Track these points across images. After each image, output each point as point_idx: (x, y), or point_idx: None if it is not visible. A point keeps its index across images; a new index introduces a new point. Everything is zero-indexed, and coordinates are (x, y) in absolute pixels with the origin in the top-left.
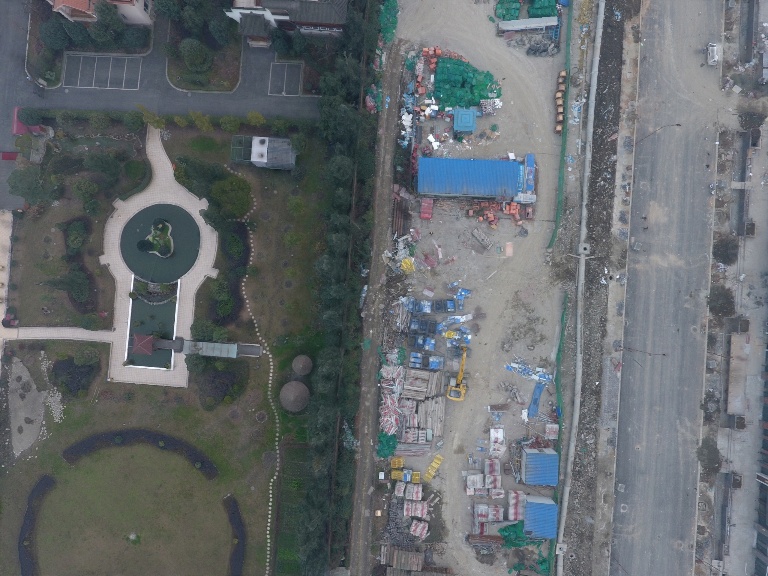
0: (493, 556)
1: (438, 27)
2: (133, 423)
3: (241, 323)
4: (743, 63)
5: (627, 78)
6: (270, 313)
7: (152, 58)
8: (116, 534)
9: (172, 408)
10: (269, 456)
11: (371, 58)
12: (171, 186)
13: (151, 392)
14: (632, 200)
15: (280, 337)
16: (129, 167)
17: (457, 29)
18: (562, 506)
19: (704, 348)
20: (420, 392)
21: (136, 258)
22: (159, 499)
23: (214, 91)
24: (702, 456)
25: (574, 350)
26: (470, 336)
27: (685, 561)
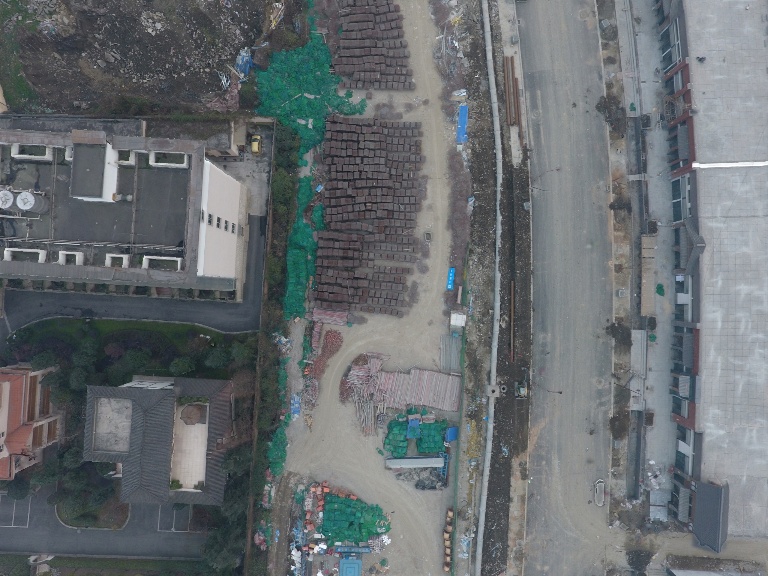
0: None
1: (327, 459)
2: None
3: None
4: (630, 500)
5: (515, 516)
6: None
7: (41, 495)
8: None
9: None
10: None
11: (258, 500)
12: None
13: None
14: None
15: None
16: None
17: (346, 462)
18: None
19: None
20: None
21: None
22: None
23: (103, 528)
24: None
25: None
26: None
27: None
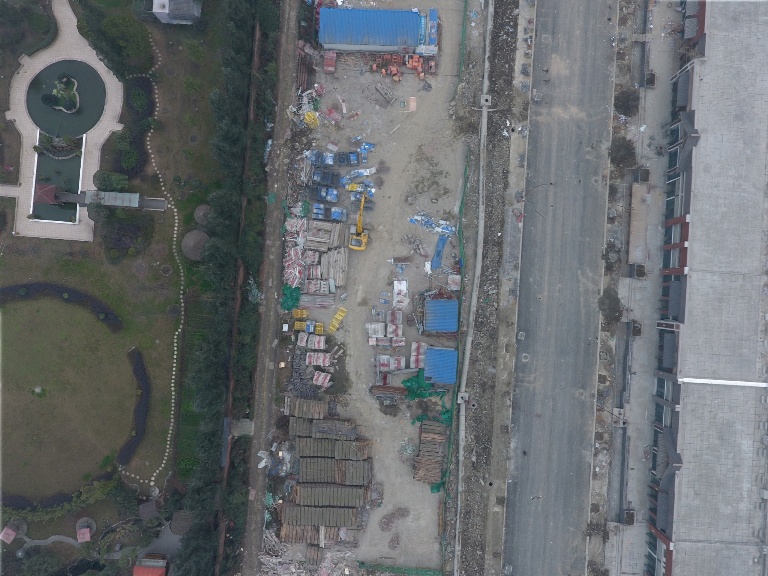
0: (397, 407)
1: None
2: (39, 277)
3: (145, 176)
4: None
5: None
6: (175, 168)
7: None
8: (21, 387)
9: (77, 262)
10: (173, 309)
11: None
12: (77, 42)
13: (57, 246)
14: (534, 53)
15: (175, 176)
16: (32, 18)
17: None
18: (464, 356)
19: (605, 199)
20: (323, 243)
21: (42, 114)
22: (64, 352)
23: None
24: (603, 305)
25: (477, 203)
26: (374, 189)
27: (586, 410)
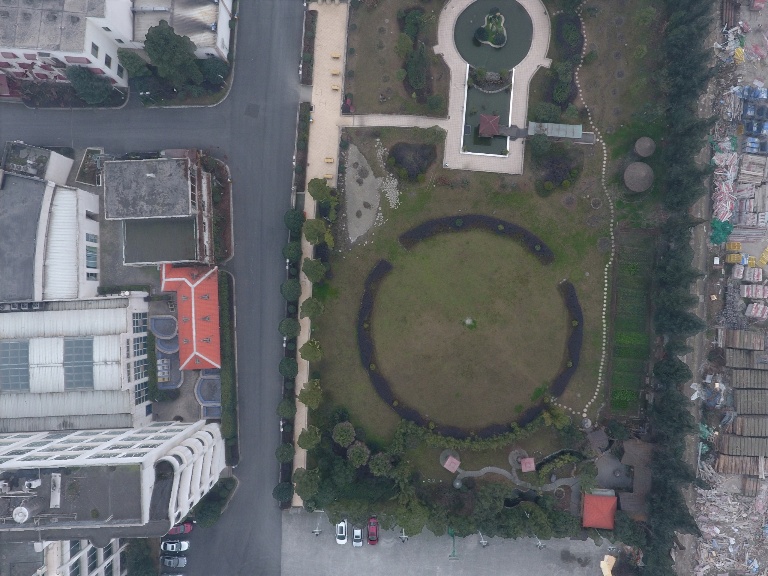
0: None
1: None
2: (468, 209)
3: None
4: None
5: None
6: (602, 102)
7: None
8: (452, 319)
9: (507, 195)
10: (605, 241)
11: None
12: None
13: (486, 179)
14: None
15: (648, 103)
16: None
17: None
18: None
19: None
20: (757, 176)
21: (469, 49)
22: (495, 284)
23: None
24: None
25: None
26: None
27: None
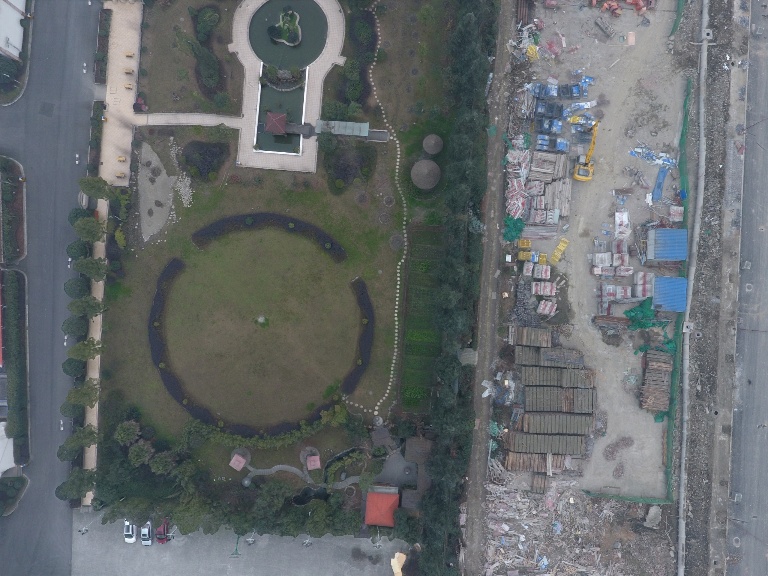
0: (619, 338)
1: None
2: (261, 208)
3: (370, 108)
4: None
5: None
6: (397, 100)
7: None
8: (245, 317)
9: (300, 193)
10: (397, 239)
11: None
12: None
13: (279, 177)
14: None
15: None
16: None
17: None
18: (688, 286)
19: None
20: (547, 174)
21: (264, 47)
22: (287, 282)
23: None
24: None
25: (697, 135)
26: (594, 122)
27: None
